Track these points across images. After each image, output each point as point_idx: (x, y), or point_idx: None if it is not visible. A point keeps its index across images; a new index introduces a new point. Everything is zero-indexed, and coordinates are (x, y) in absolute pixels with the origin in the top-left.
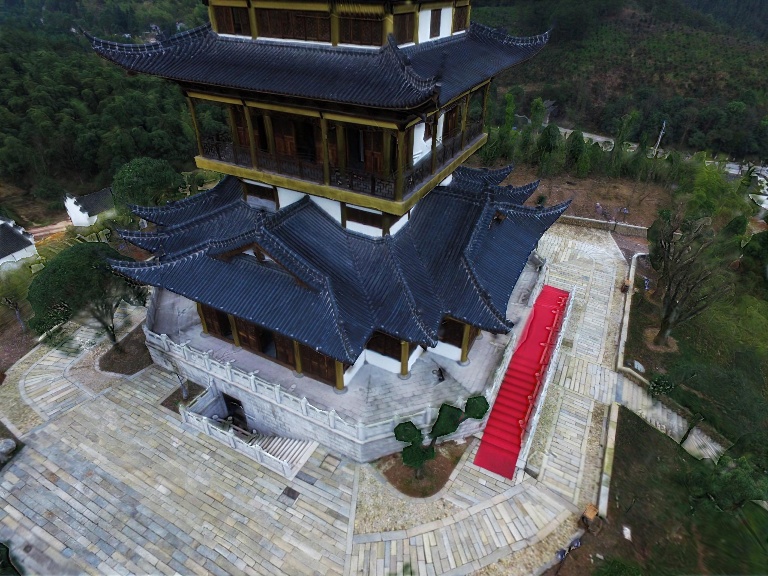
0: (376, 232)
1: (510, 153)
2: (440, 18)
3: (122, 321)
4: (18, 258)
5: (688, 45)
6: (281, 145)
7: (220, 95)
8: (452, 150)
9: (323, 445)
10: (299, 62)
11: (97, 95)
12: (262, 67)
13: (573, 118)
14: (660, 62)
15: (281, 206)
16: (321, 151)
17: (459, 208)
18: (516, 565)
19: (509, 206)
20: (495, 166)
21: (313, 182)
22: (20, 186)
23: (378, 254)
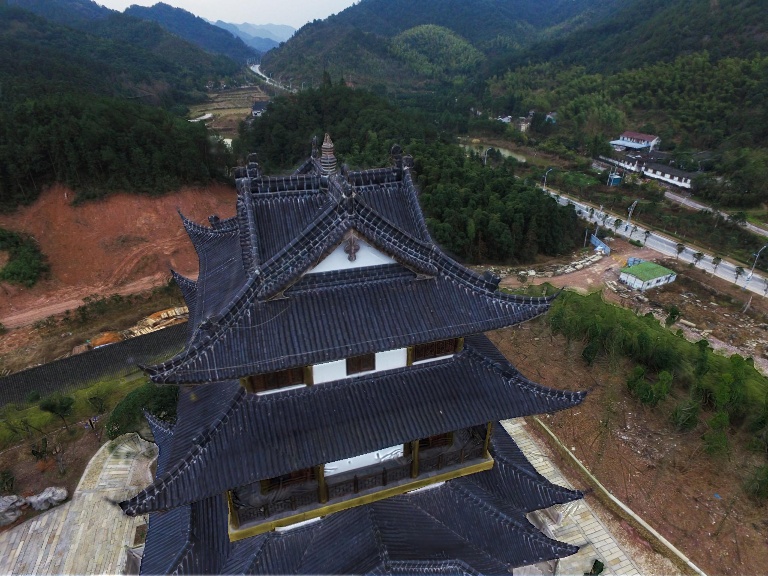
0: None
1: (741, 423)
2: (375, 355)
3: None
4: None
5: None
6: None
7: None
8: (383, 478)
9: None
10: None
11: (428, 180)
12: None
13: None
14: None
15: None
16: None
17: (366, 545)
18: None
19: (467, 569)
20: (689, 435)
21: None
22: None
23: (260, 541)
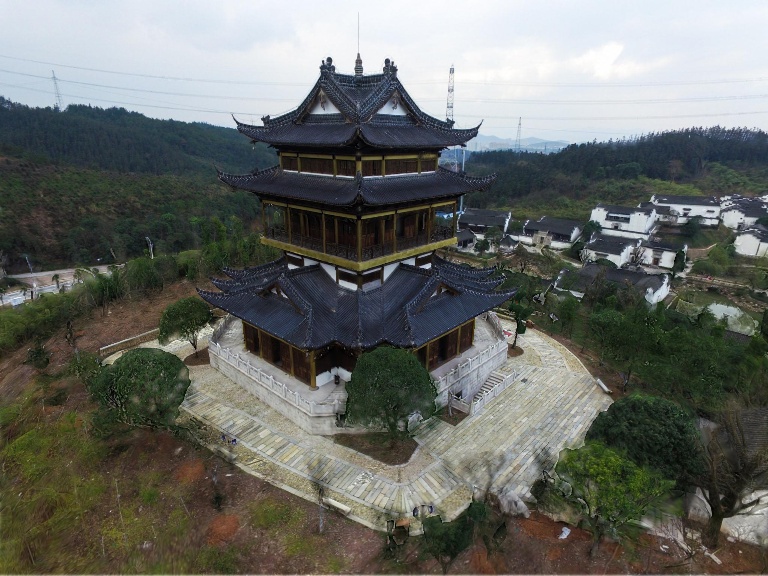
0: (429, 266)
1: None
2: None
3: (335, 459)
4: None
5: (85, 181)
6: (387, 237)
7: (386, 211)
8: None
9: (495, 370)
10: (417, 183)
11: None
12: (411, 188)
13: (35, 261)
14: (74, 197)
15: (384, 280)
16: (407, 231)
17: None
18: (550, 340)
19: None
20: None
21: (423, 245)
22: None
23: None
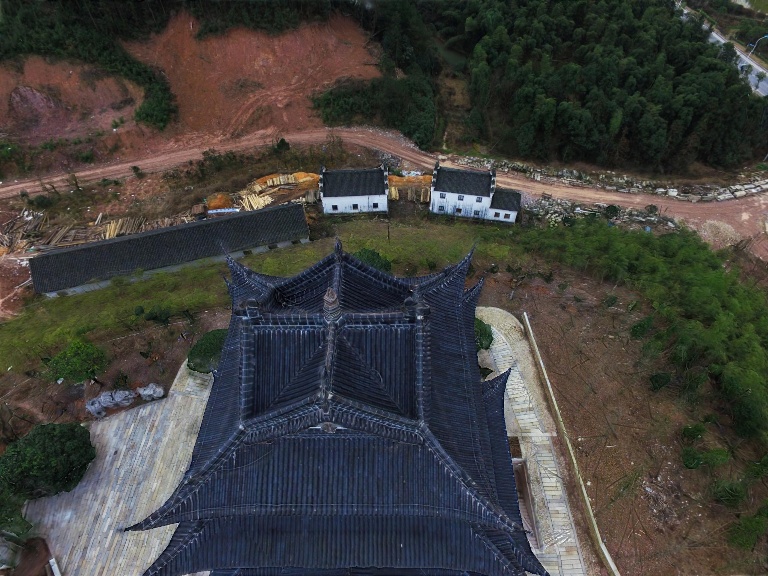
0: None
1: None
2: None
3: None
4: (372, 199)
5: None
6: None
7: None
8: None
9: None
10: None
11: (587, 36)
12: None
13: None
14: None
15: None
16: None
17: (339, 573)
18: None
19: None
20: (723, 508)
21: None
22: (471, 100)
23: None
